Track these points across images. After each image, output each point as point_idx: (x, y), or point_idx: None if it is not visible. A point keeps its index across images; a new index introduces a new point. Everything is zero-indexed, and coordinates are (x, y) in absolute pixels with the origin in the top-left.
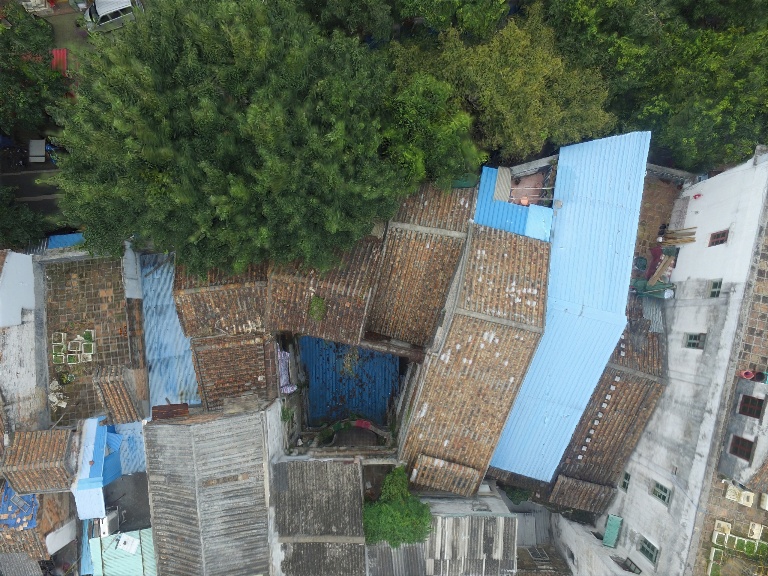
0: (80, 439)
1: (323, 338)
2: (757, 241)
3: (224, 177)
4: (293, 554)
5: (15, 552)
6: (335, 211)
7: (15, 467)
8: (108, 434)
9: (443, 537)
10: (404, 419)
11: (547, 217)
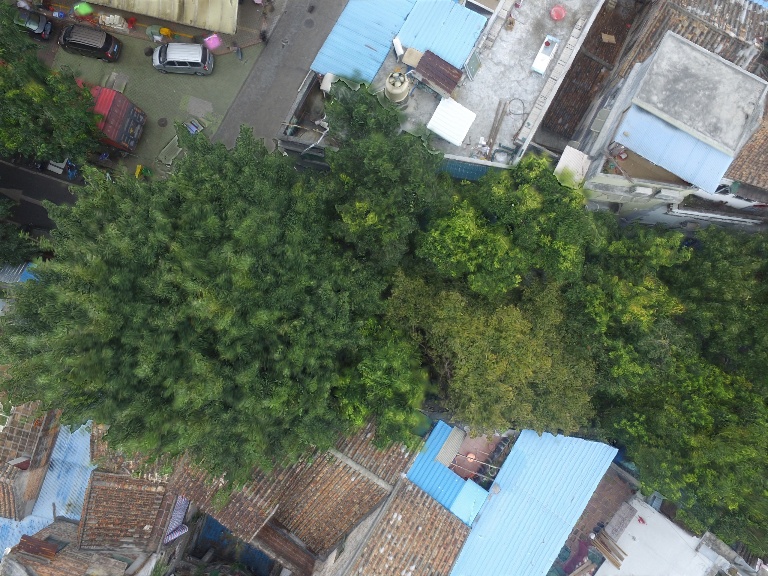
0: None
1: None
2: None
3: (152, 403)
4: None
5: None
6: None
7: None
8: None
9: None
10: None
11: (479, 499)
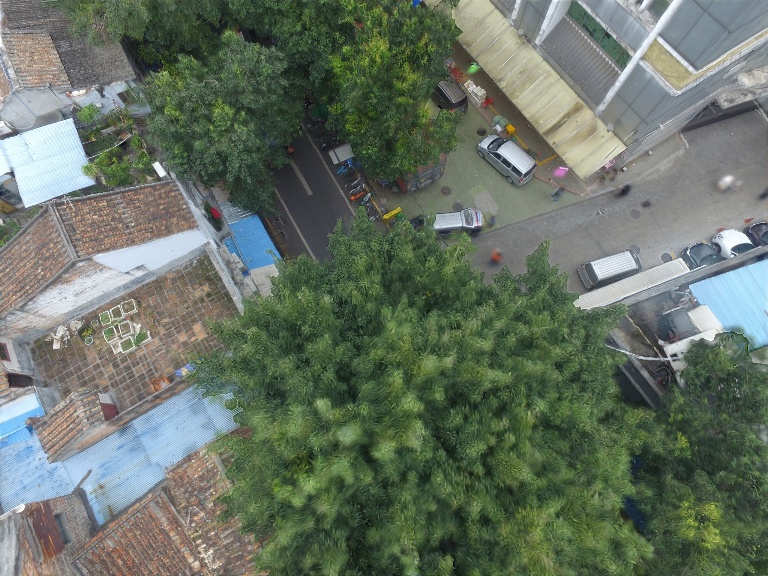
0: (5, 403)
1: None
2: None
3: None
4: None
5: None
6: None
7: None
8: (22, 429)
9: None
10: None
11: None
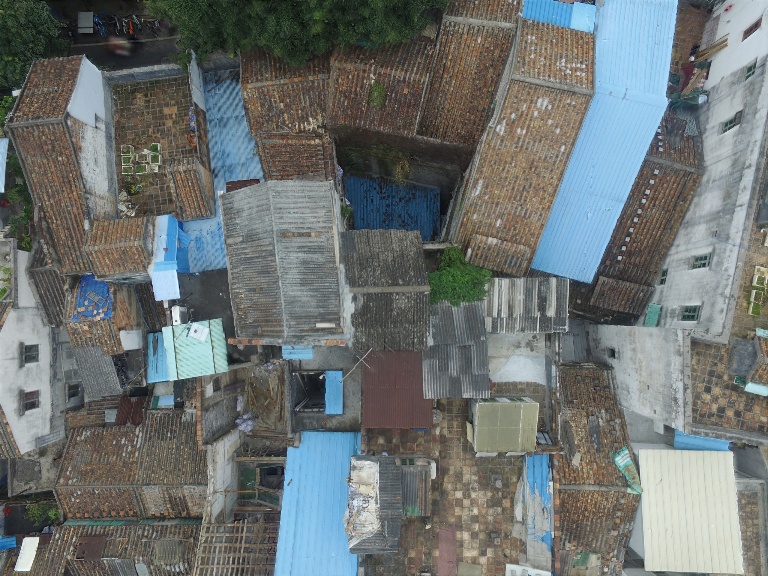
0: (154, 230)
1: (381, 131)
2: None
3: None
4: (362, 306)
5: (91, 345)
6: None
7: (97, 246)
8: (179, 228)
9: (500, 297)
10: None
11: (591, 13)
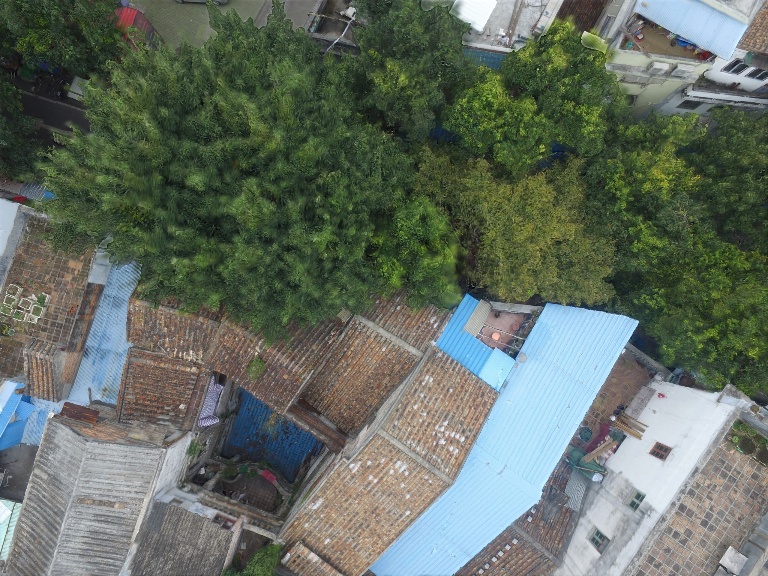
0: None
1: (253, 395)
2: (688, 480)
3: (199, 237)
4: None
5: None
6: (300, 296)
7: None
8: (21, 402)
9: None
10: (302, 495)
11: (507, 366)
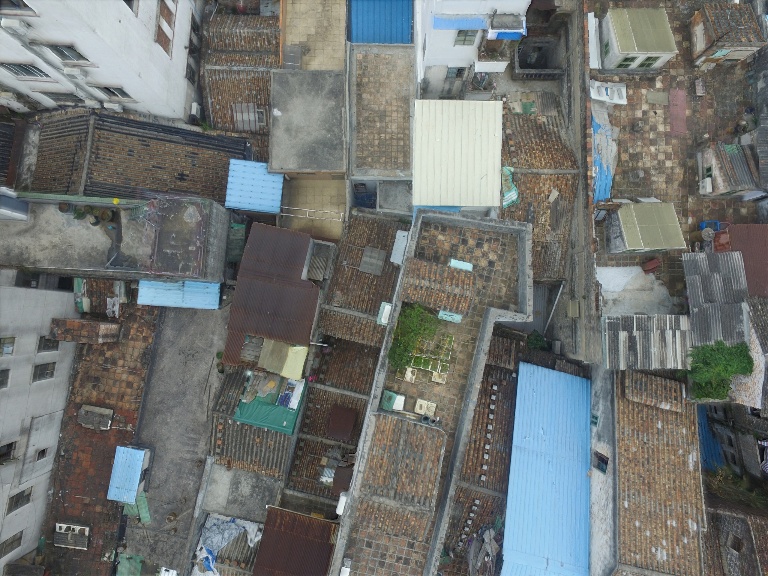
0: None
1: None
2: None
3: None
4: None
5: None
6: None
7: None
8: None
9: (675, 350)
10: None
11: None
